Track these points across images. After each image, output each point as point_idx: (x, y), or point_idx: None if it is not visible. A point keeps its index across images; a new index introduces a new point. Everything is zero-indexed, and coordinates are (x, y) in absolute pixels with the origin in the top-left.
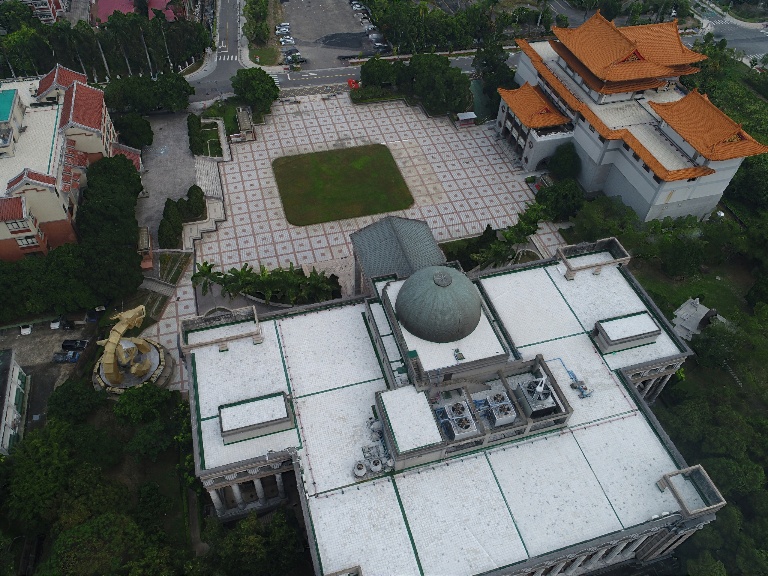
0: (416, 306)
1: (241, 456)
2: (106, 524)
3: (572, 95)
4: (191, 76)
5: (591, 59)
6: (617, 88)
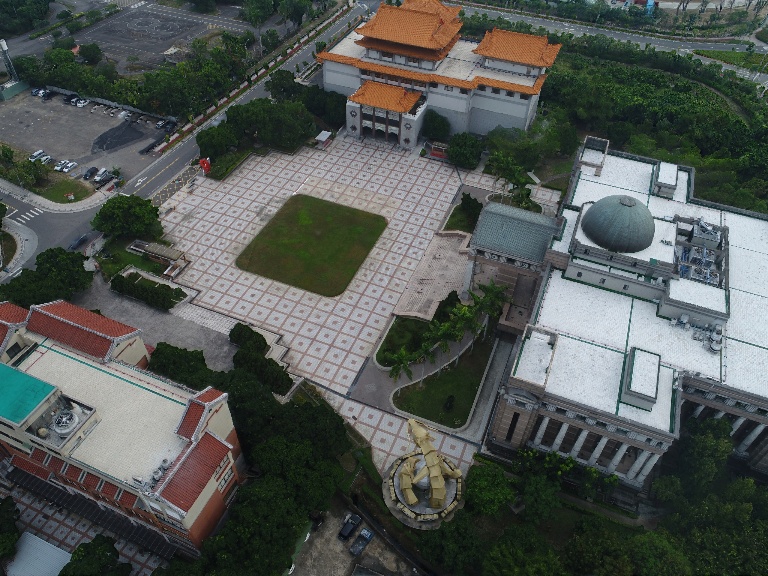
0: (633, 229)
1: (666, 407)
2: (649, 547)
3: (416, 72)
4: (21, 254)
5: (413, 39)
6: (443, 52)
